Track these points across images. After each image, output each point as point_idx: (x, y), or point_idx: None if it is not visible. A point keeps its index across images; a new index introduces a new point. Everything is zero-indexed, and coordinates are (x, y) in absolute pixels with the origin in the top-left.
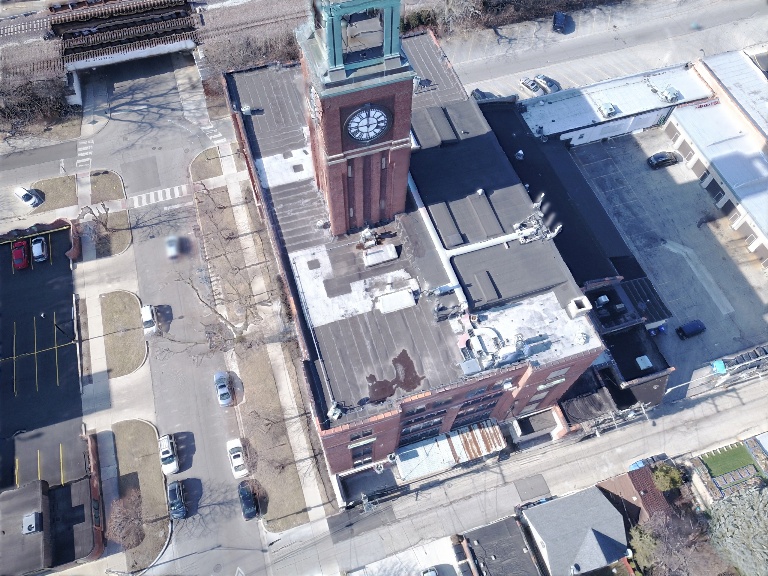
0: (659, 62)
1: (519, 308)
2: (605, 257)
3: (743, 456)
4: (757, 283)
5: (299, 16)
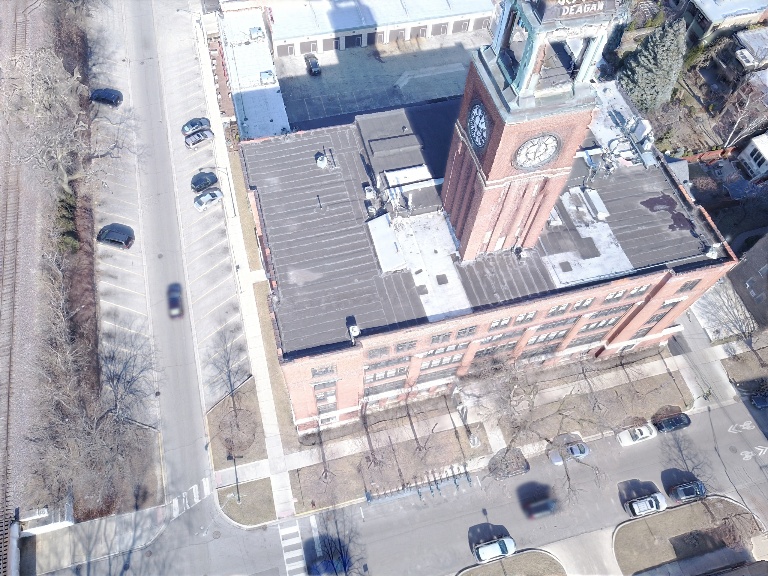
0: (186, 41)
1: None
2: None
3: None
4: (438, 44)
5: (7, 363)
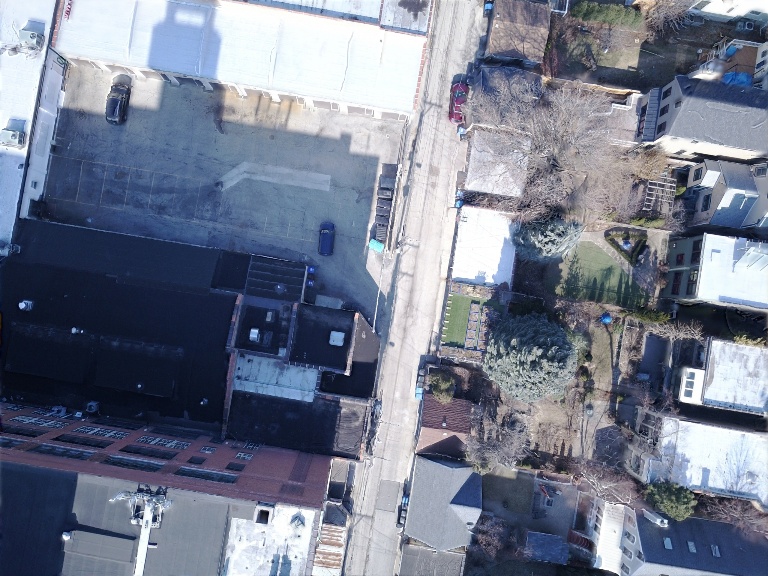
0: None
1: (232, 565)
2: (208, 293)
3: (461, 304)
4: (315, 128)
5: None
